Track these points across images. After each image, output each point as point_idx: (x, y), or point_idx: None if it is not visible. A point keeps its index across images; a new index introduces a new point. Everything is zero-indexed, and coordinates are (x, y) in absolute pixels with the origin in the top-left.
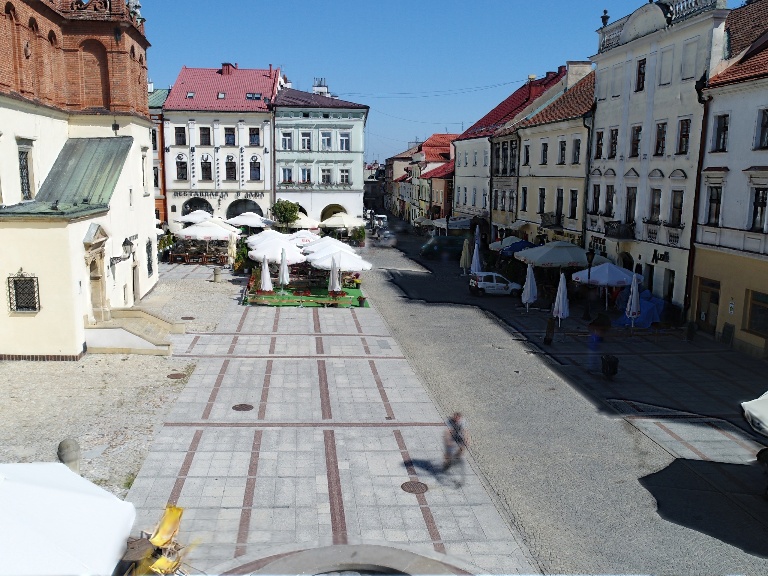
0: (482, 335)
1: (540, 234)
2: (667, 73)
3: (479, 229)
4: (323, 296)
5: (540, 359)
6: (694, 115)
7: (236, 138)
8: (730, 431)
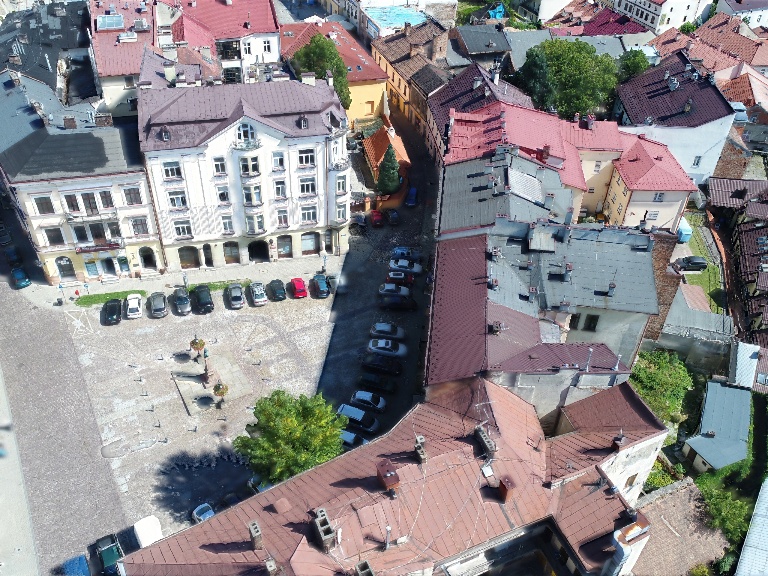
0: (279, 8)
1: None
2: None
3: None
4: None
5: (289, 13)
6: None
7: None
8: None
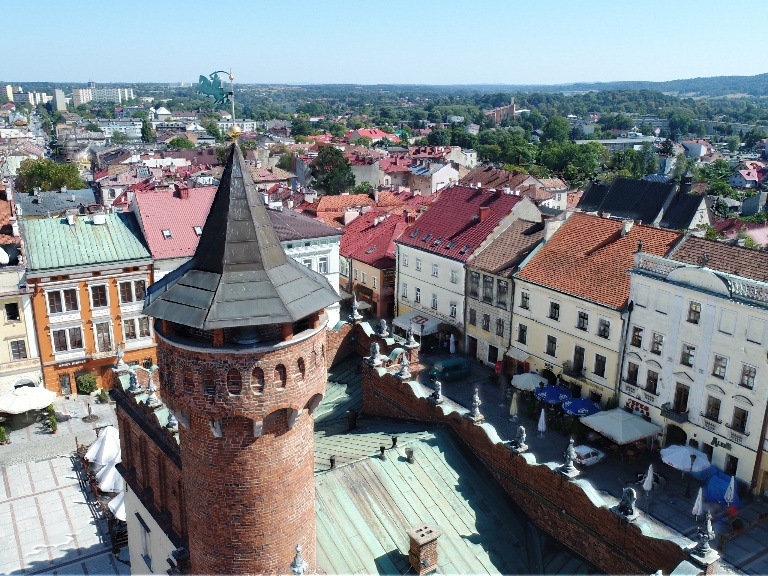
0: None
1: (550, 370)
2: (728, 326)
3: (454, 338)
4: None
5: None
6: (761, 369)
7: None
8: None
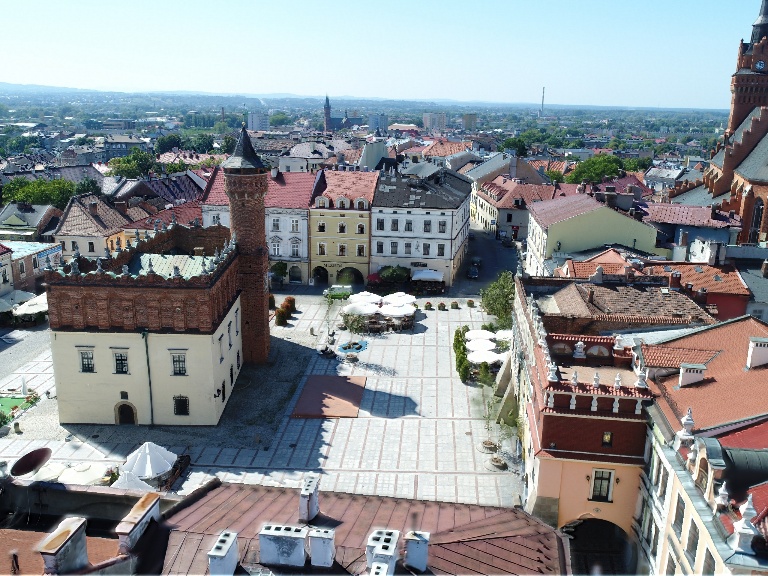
0: None
1: None
2: None
3: None
4: (3, 390)
5: None
6: None
7: None
8: (8, 335)
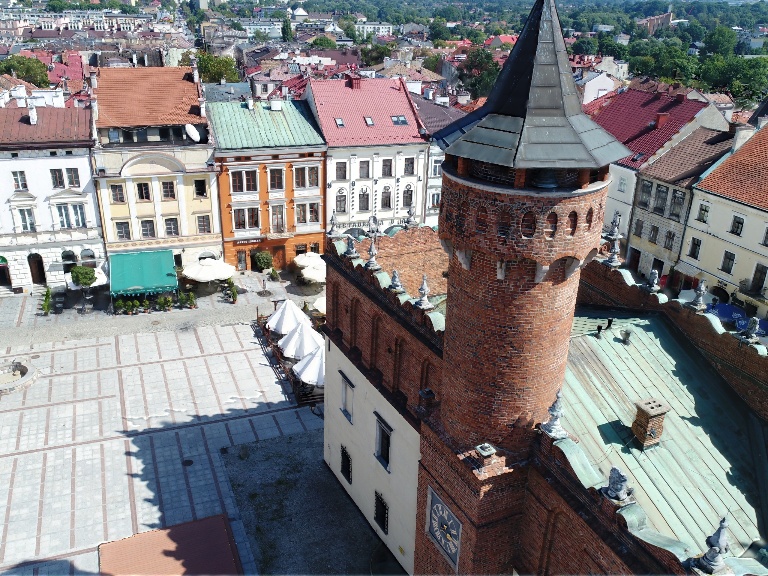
0: None
1: (722, 288)
2: None
3: None
4: None
5: None
6: None
7: (393, 169)
8: None
